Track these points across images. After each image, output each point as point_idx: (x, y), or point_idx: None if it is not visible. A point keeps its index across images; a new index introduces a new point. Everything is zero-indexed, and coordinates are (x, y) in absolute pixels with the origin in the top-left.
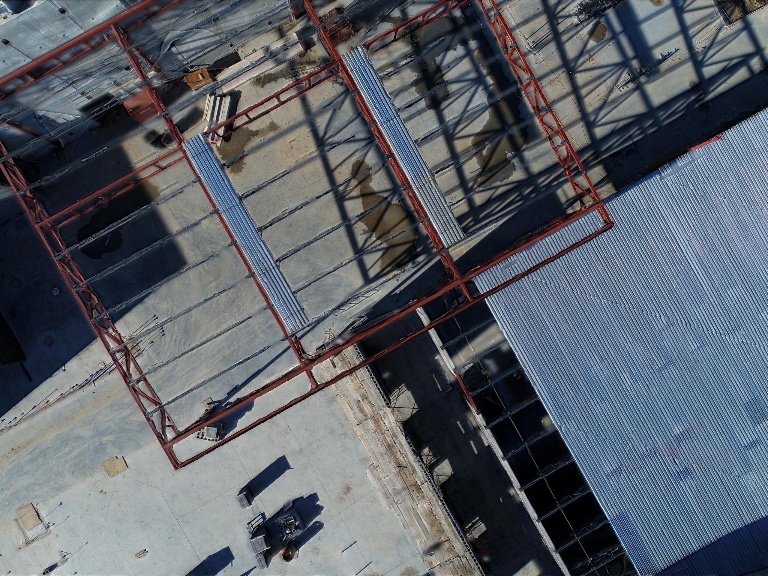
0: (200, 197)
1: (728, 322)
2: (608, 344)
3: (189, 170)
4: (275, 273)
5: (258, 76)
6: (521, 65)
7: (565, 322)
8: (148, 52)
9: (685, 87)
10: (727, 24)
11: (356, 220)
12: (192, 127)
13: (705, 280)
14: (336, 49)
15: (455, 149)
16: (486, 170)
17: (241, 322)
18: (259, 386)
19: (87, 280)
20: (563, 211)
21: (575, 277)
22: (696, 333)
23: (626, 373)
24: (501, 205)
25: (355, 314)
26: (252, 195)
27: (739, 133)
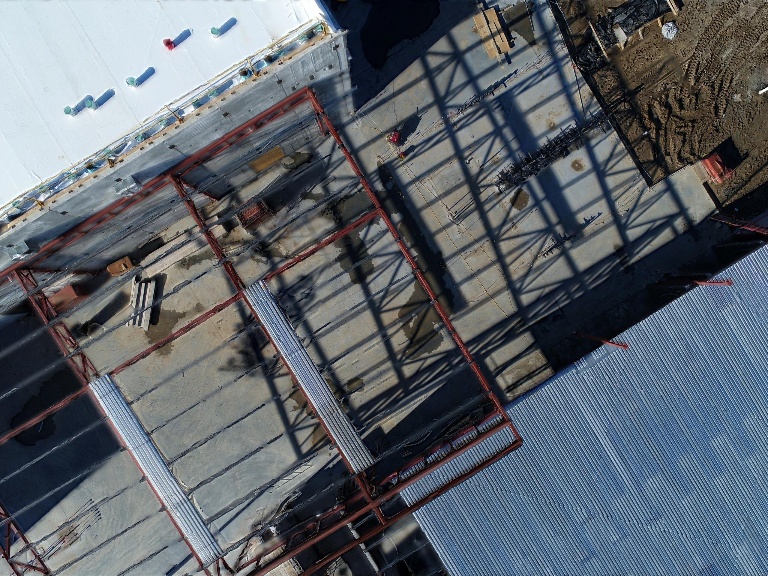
0: (130, 381)
1: (649, 512)
2: (530, 540)
3: (118, 354)
4: (187, 507)
5: (183, 259)
6: (445, 236)
7: (486, 520)
8: (62, 266)
9: (610, 250)
10: (650, 185)
11: (286, 397)
12: (119, 312)
13: (625, 472)
14: (259, 229)
15: (382, 322)
16: (414, 342)
17: (158, 552)
18: (197, 565)
19: (2, 522)
20: (492, 379)
21: (495, 475)
22: (618, 525)
23: (549, 567)
24: (430, 376)
25: (289, 490)
26: (182, 376)
27: (654, 323)
